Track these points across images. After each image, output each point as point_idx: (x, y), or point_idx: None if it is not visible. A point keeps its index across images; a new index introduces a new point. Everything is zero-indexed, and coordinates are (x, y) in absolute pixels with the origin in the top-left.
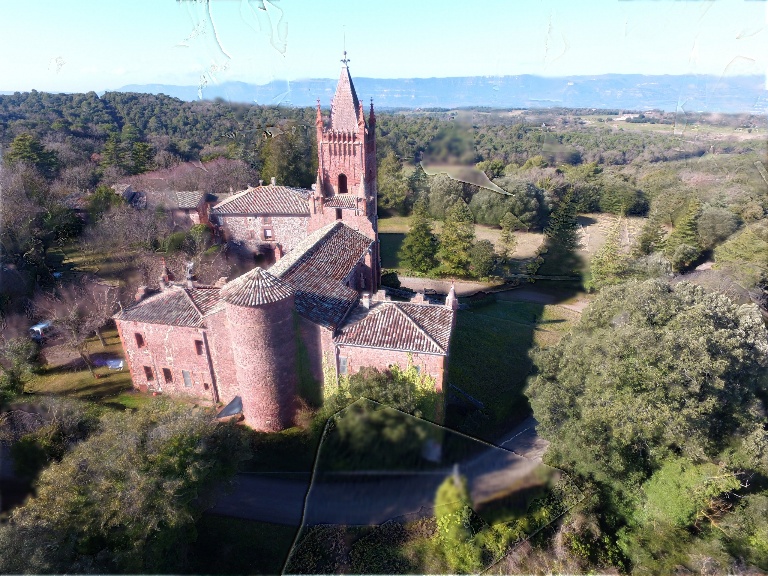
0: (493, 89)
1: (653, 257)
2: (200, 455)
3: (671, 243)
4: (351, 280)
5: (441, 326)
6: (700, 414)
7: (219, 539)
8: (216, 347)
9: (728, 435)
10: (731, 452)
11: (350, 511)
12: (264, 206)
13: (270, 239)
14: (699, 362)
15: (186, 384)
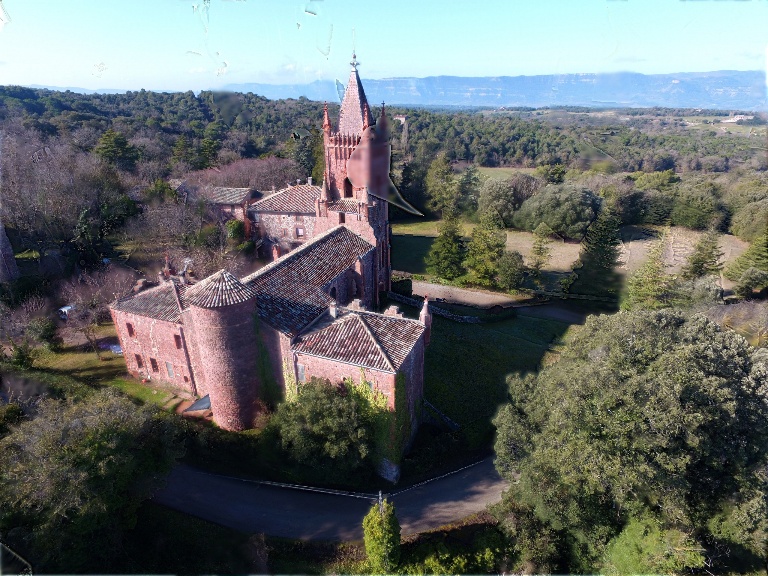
0: (552, 90)
1: (702, 281)
2: (123, 449)
3: (742, 265)
4: (339, 286)
5: (403, 342)
6: (672, 472)
7: (157, 529)
8: (192, 343)
9: (725, 499)
10: (721, 520)
11: None
12: (297, 205)
13: (302, 237)
14: (666, 413)
15: (169, 375)
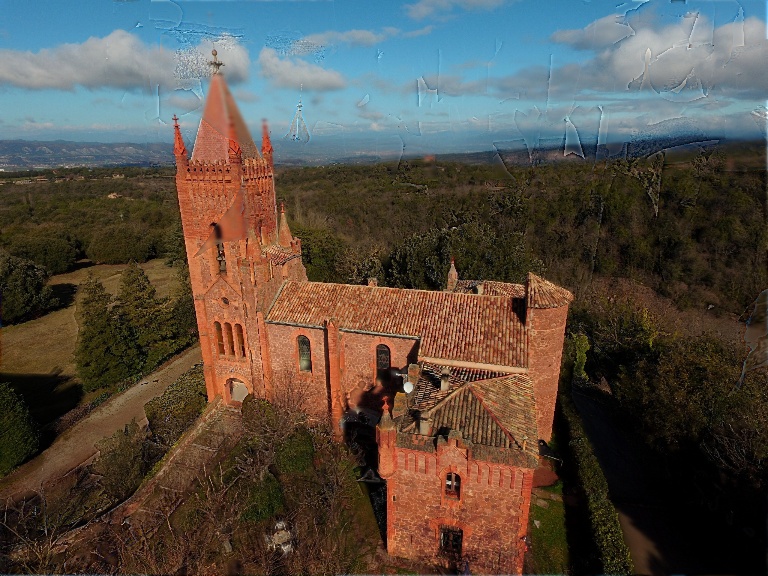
0: None
1: None
2: None
3: None
4: None
5: None
6: None
7: None
8: None
9: None
10: None
11: None
12: None
13: None
14: None
15: None
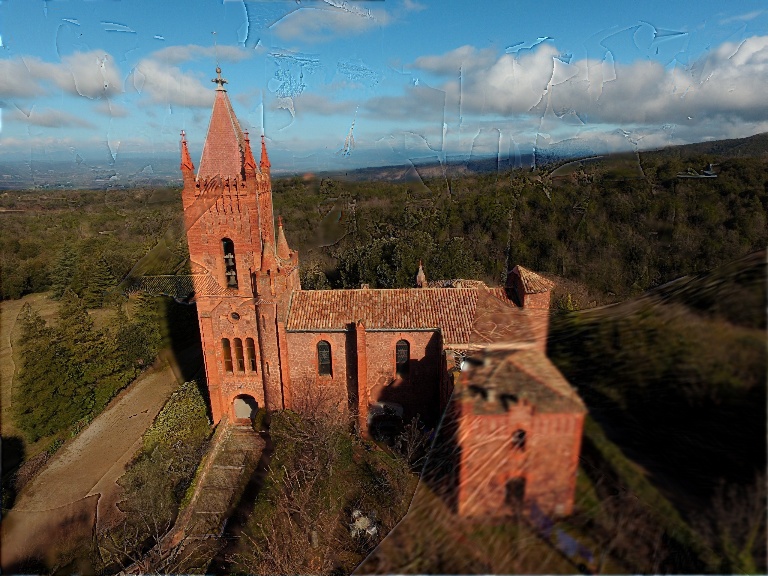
0: None
1: None
2: None
3: None
4: None
5: None
6: None
7: None
8: None
9: None
10: None
11: (694, 174)
12: None
13: None
14: None
15: None
